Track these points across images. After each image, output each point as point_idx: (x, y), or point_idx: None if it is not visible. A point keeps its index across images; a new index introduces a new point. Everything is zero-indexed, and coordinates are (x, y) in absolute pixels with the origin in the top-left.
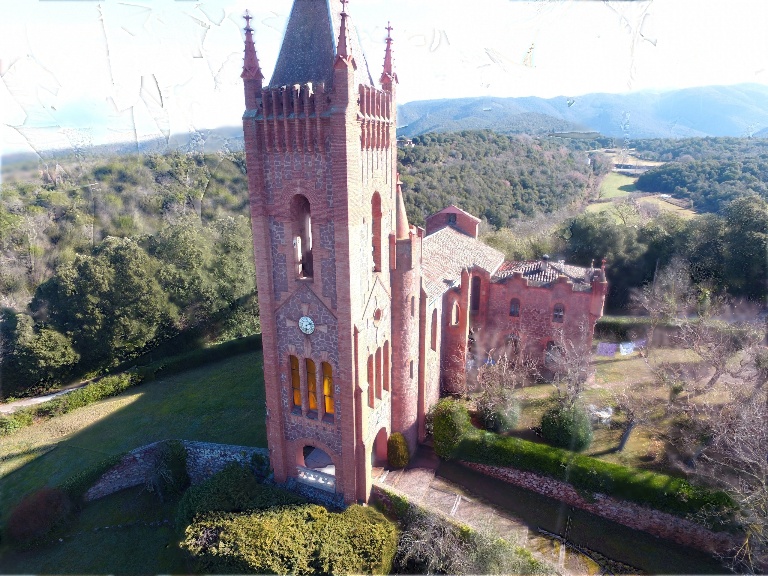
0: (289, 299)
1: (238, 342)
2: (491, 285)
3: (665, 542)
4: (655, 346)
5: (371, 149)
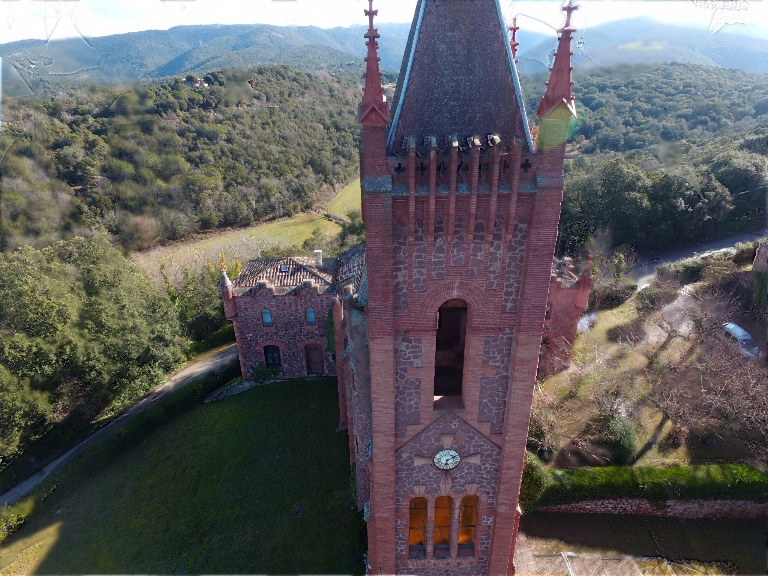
0: (421, 433)
1: (153, 413)
2: None
3: (722, 522)
4: (589, 312)
5: None
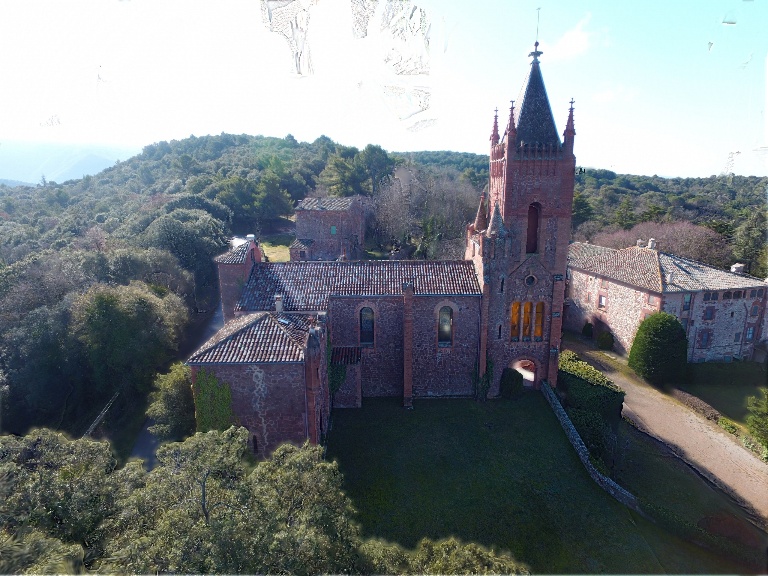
0: None
1: None
2: None
3: None
4: None
5: None
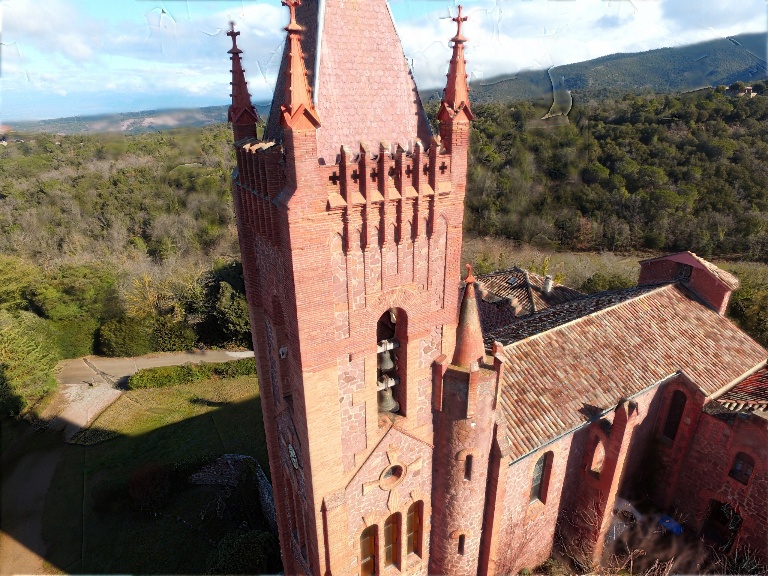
0: (281, 414)
1: None
2: (704, 414)
3: None
4: None
5: (379, 246)
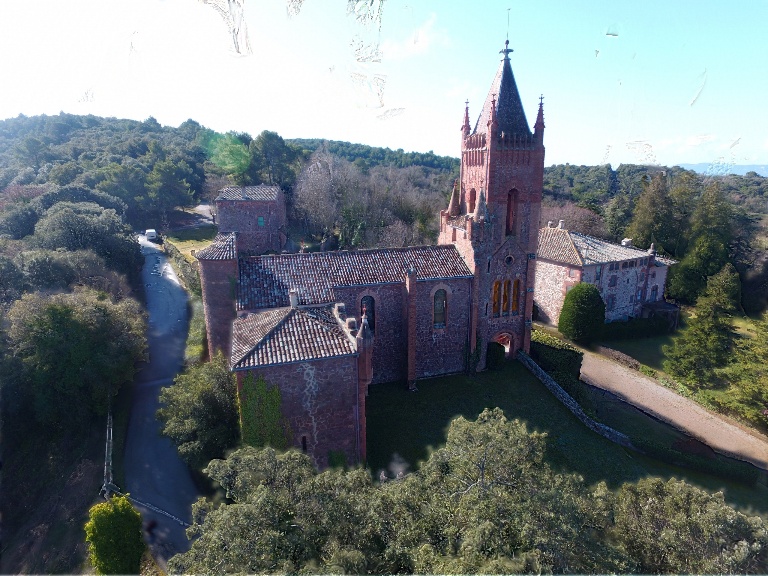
0: None
1: None
2: None
3: None
4: None
5: None
